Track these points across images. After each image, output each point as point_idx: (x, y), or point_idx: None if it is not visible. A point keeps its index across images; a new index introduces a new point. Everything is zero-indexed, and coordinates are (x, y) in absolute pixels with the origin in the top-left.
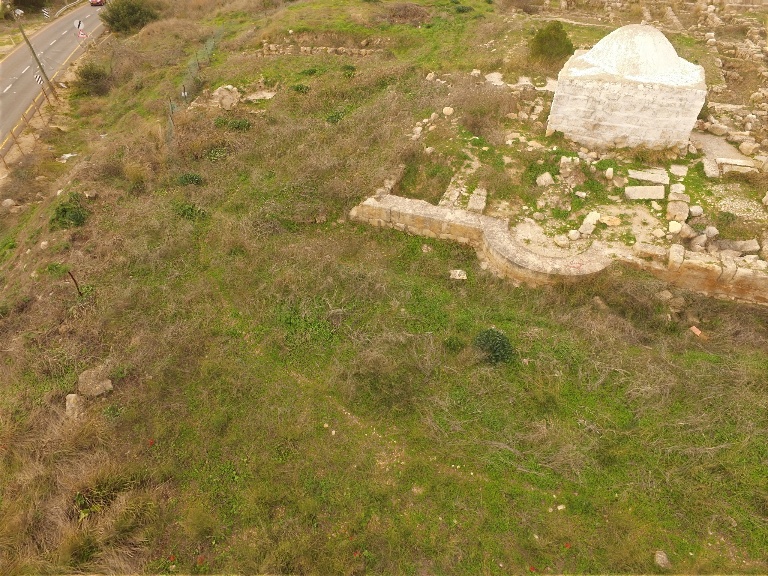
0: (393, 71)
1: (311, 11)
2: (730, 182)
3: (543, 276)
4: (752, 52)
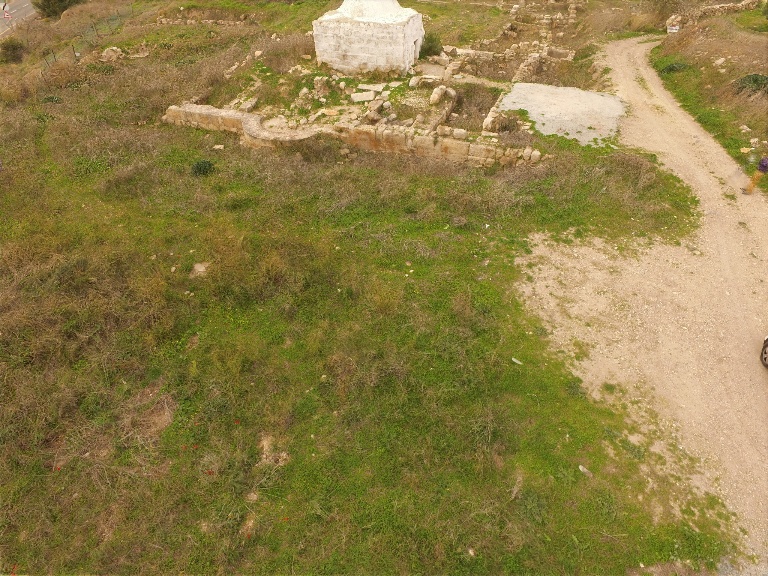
0: (245, 33)
1: None
2: (422, 89)
3: (268, 143)
4: None
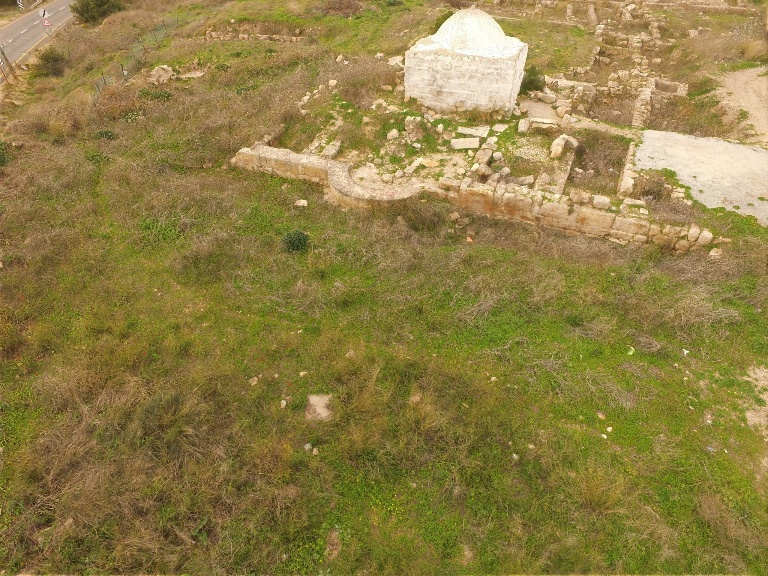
0: (308, 54)
1: (256, 3)
2: (534, 136)
3: (362, 202)
4: (633, 42)
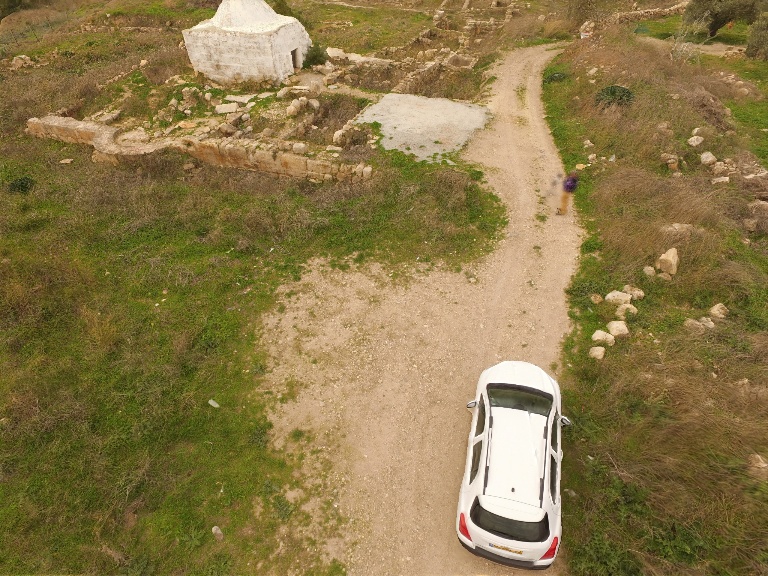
0: (153, 41)
1: None
2: (288, 100)
3: (112, 157)
4: None
